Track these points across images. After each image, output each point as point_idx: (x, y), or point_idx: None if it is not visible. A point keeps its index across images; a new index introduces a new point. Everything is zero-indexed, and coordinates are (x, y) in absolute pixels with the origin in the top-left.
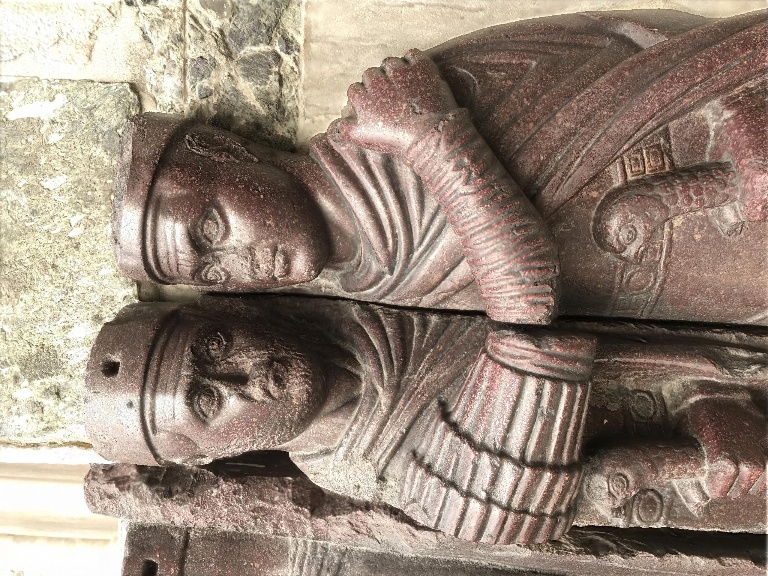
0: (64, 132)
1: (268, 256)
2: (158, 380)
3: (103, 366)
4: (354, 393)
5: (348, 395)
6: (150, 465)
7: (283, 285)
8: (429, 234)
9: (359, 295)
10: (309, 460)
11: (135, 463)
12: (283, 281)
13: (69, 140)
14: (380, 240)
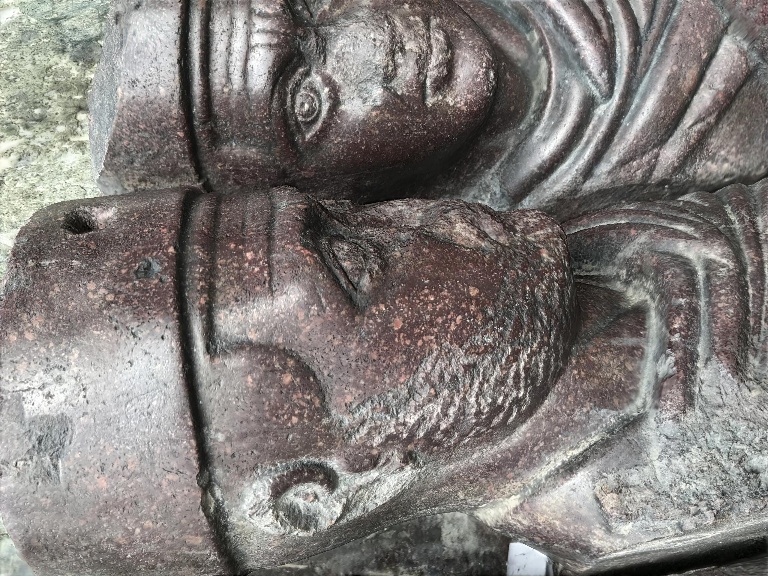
0: (7, 42)
1: (419, 27)
2: (219, 222)
3: (67, 222)
4: (621, 304)
5: (613, 305)
6: (166, 537)
7: (429, 134)
8: (660, 6)
9: (540, 193)
10: (589, 460)
11: (120, 531)
12: (434, 112)
13: (14, 50)
14: (588, 20)
